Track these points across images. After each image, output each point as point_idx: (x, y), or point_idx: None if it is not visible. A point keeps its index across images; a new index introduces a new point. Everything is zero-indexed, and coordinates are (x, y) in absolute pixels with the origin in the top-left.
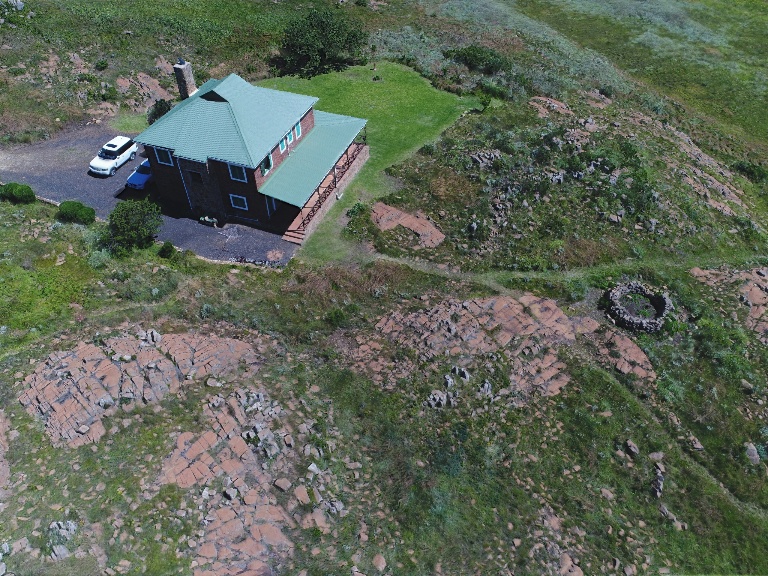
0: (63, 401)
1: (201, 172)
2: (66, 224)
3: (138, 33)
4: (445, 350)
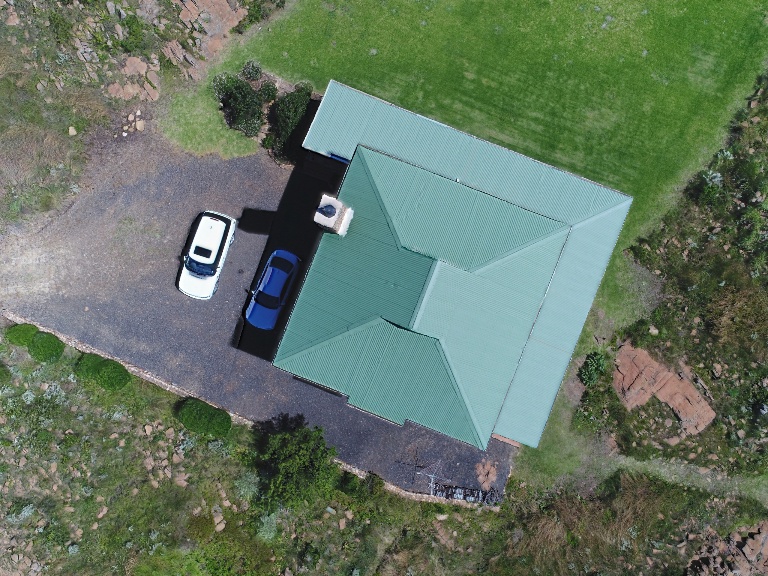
0: None
1: None
2: (195, 434)
3: None
4: None
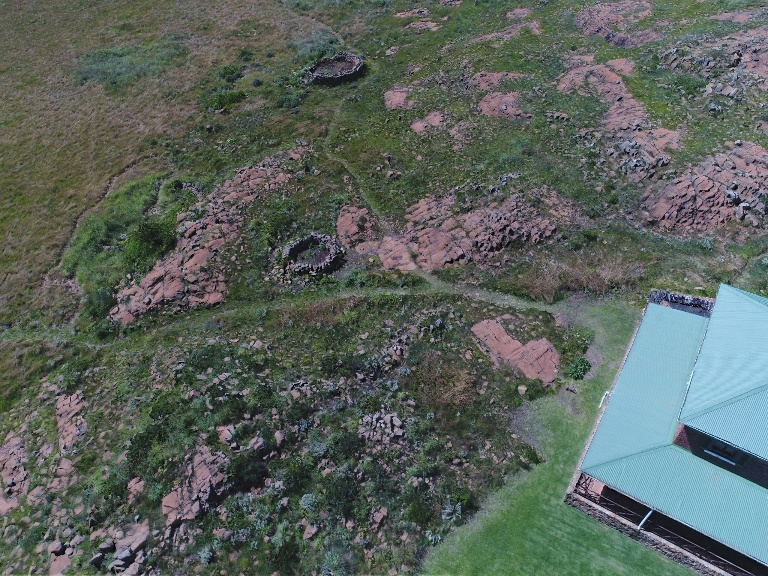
0: (764, 156)
1: None
2: None
3: None
4: None
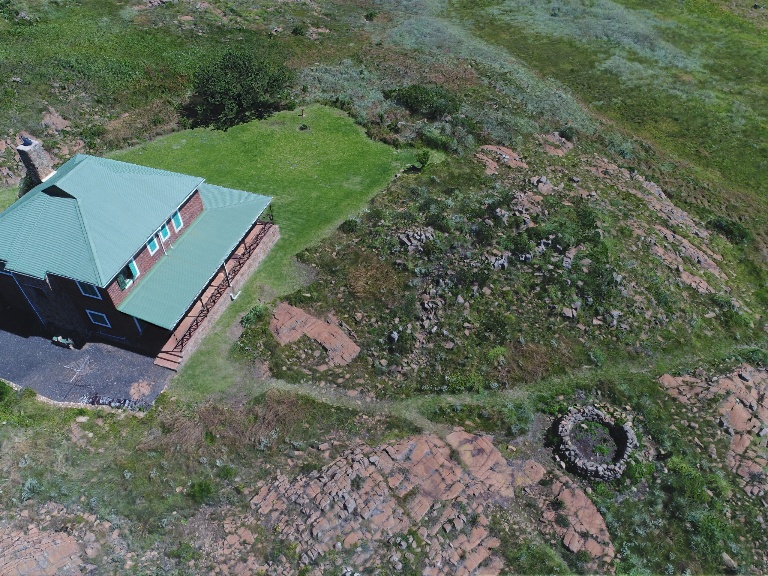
0: None
1: (43, 288)
2: None
3: (27, 80)
4: (336, 543)
